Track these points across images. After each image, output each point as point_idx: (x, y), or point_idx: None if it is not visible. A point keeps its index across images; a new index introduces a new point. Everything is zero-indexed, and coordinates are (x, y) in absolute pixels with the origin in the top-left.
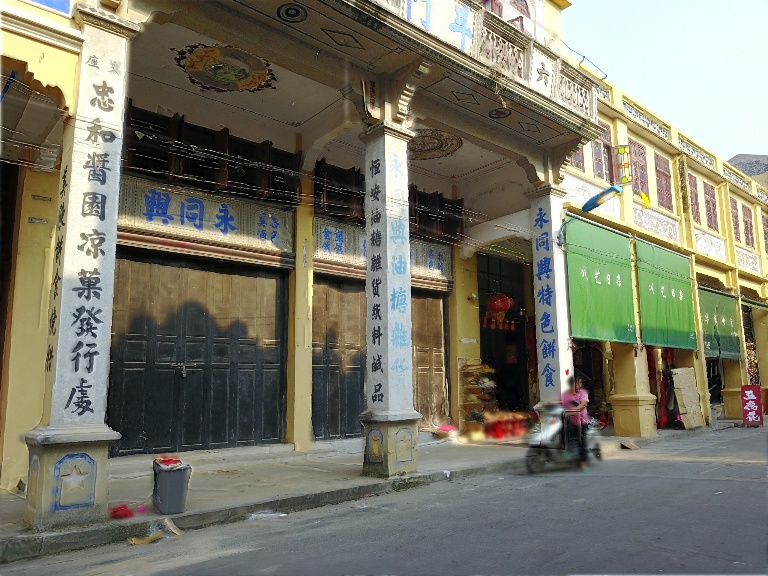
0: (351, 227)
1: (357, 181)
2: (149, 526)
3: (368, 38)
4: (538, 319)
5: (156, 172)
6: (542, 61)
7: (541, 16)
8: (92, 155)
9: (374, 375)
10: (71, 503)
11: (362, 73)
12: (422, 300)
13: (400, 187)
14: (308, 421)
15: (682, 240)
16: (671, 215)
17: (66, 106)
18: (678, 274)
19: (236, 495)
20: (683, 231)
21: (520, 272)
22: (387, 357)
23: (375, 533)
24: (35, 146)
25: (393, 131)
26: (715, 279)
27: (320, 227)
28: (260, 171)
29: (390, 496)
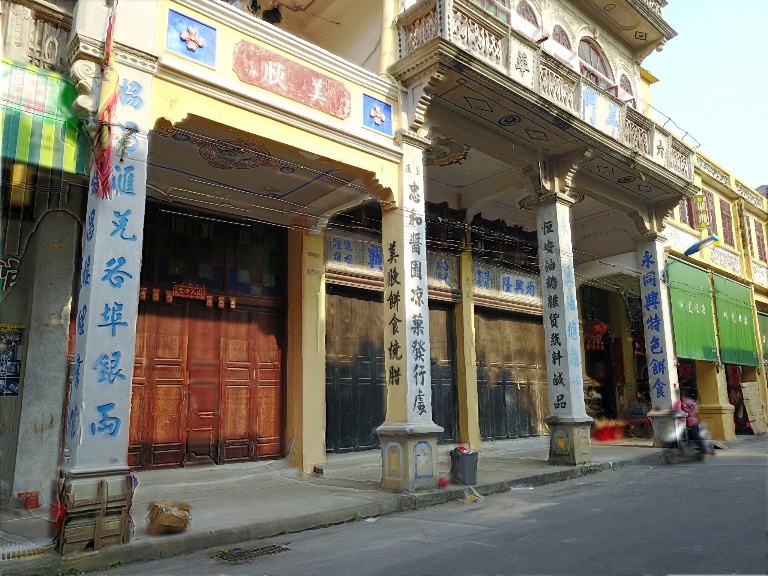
0: (494, 267)
1: (502, 230)
2: (464, 492)
3: (555, 134)
4: (648, 342)
5: (426, 240)
6: (660, 139)
7: (640, 93)
8: (412, 234)
9: (556, 388)
10: (422, 475)
11: (538, 156)
12: (540, 326)
13: (567, 243)
14: (477, 425)
15: (743, 272)
16: (734, 251)
17: (394, 200)
18: (744, 302)
19: (487, 475)
20: (743, 264)
21: (606, 300)
22: (568, 374)
23: (626, 495)
24: (313, 216)
25: (562, 200)
26: (766, 304)
27: (474, 268)
28: (439, 226)
29: (586, 478)
